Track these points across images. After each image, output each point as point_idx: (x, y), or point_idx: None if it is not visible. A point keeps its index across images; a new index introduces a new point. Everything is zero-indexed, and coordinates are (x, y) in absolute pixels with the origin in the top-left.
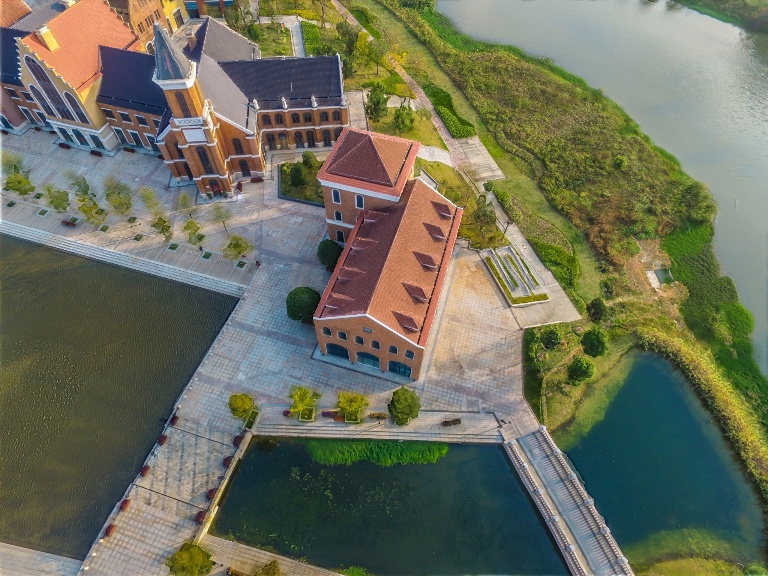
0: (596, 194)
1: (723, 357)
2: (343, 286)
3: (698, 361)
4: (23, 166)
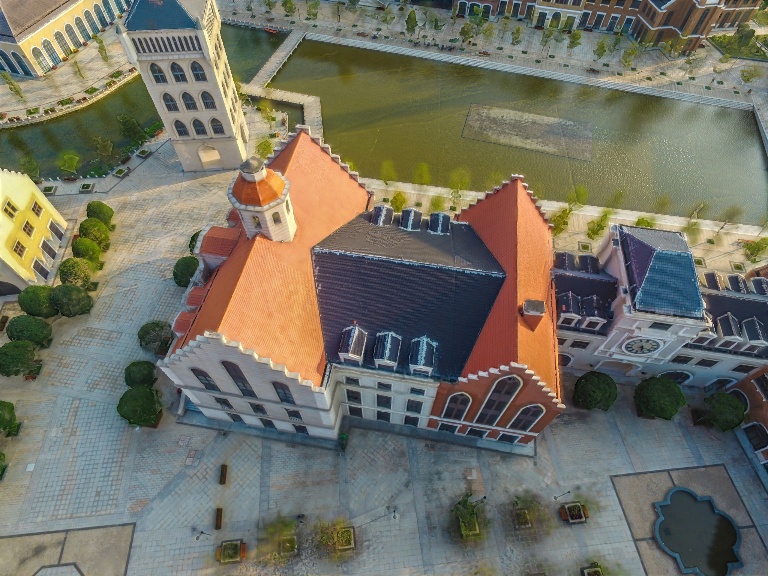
0: None
1: None
2: None
3: None
4: (521, 40)
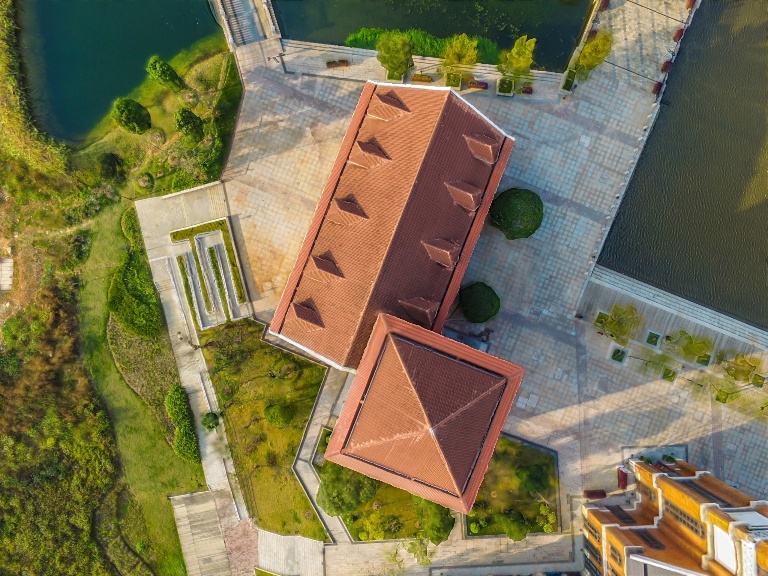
0: (27, 444)
1: None
2: (474, 178)
3: (4, 118)
4: None
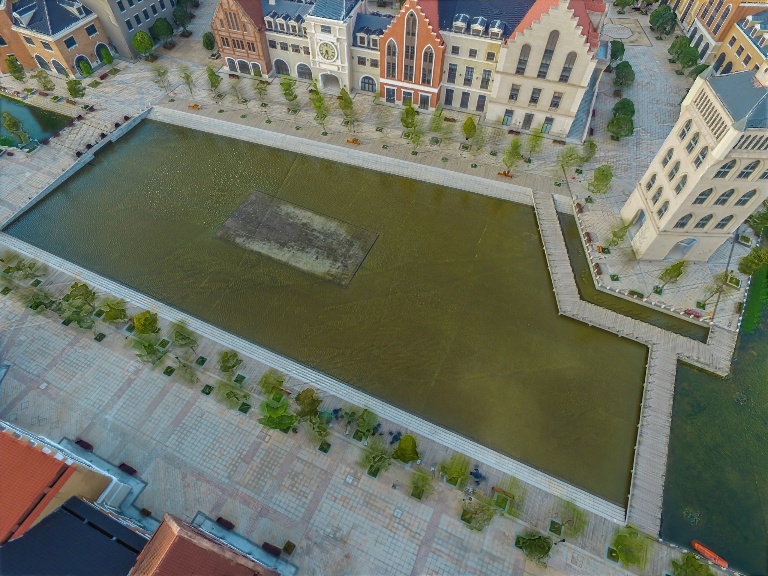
0: None
1: None
2: None
3: None
4: (191, 432)
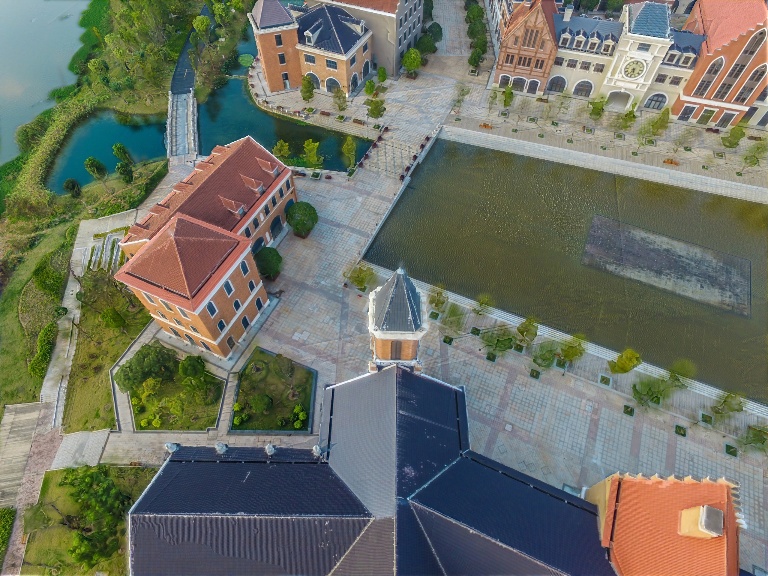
0: None
1: (0, 199)
2: (261, 179)
3: None
4: None
